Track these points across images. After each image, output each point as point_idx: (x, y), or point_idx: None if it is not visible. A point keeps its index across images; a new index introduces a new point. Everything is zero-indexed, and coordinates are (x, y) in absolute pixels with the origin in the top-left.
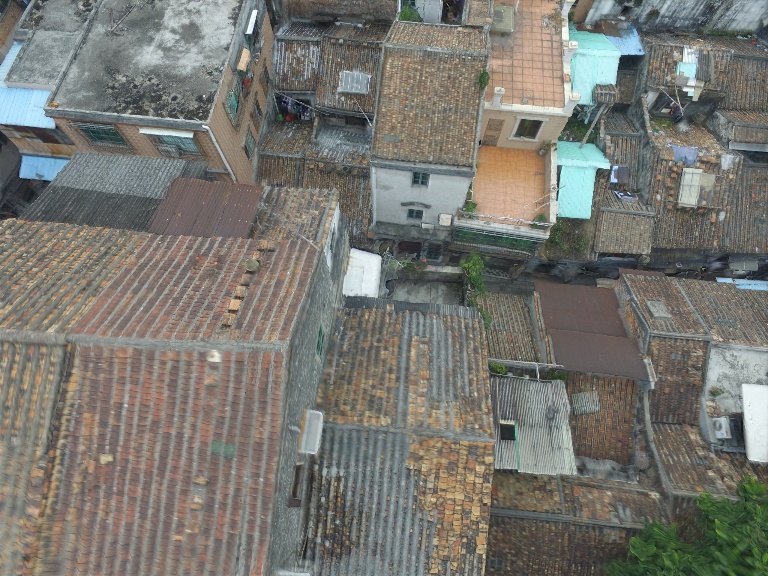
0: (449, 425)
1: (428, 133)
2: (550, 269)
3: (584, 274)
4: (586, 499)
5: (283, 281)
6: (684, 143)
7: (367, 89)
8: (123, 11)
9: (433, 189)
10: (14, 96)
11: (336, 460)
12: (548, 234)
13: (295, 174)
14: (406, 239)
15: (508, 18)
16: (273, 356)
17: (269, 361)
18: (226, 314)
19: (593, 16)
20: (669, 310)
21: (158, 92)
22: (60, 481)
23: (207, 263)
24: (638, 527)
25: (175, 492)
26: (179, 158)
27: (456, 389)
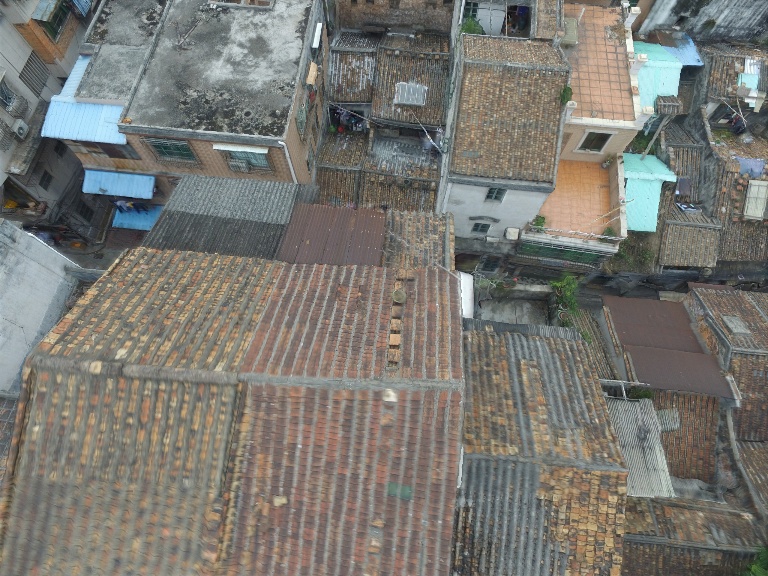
0: (578, 454)
1: (508, 149)
2: (607, 281)
3: (642, 286)
4: (678, 520)
5: (435, 313)
6: (748, 155)
7: (424, 100)
8: (189, 25)
9: (506, 204)
10: (84, 111)
11: (464, 490)
12: (617, 248)
13: (354, 187)
14: (465, 252)
15: (572, 30)
16: (450, 395)
17: (445, 400)
18: (391, 350)
19: (647, 26)
20: (746, 325)
21: (231, 107)
22: (234, 524)
23: (350, 294)
24: (735, 549)
25: (351, 535)
26: (248, 173)
27: (576, 415)
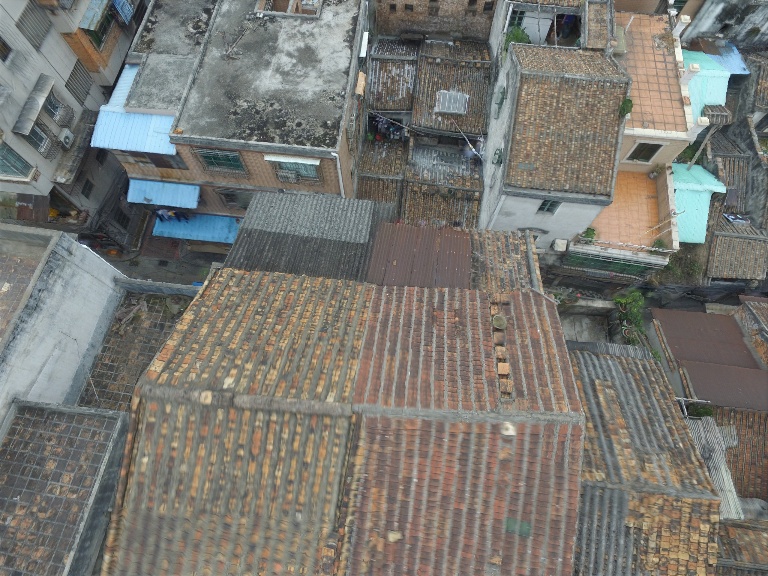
0: (667, 481)
1: (564, 161)
2: (648, 291)
3: (686, 297)
4: (744, 542)
5: (538, 340)
6: None
7: (465, 109)
8: (236, 34)
9: (558, 216)
10: (133, 121)
11: None
12: (667, 260)
13: (396, 196)
14: None
15: (620, 39)
16: (570, 429)
17: (565, 434)
18: (503, 380)
19: (690, 33)
20: None
21: (281, 118)
22: (349, 560)
23: (447, 319)
24: None
25: (469, 572)
26: (296, 183)
27: (659, 439)
